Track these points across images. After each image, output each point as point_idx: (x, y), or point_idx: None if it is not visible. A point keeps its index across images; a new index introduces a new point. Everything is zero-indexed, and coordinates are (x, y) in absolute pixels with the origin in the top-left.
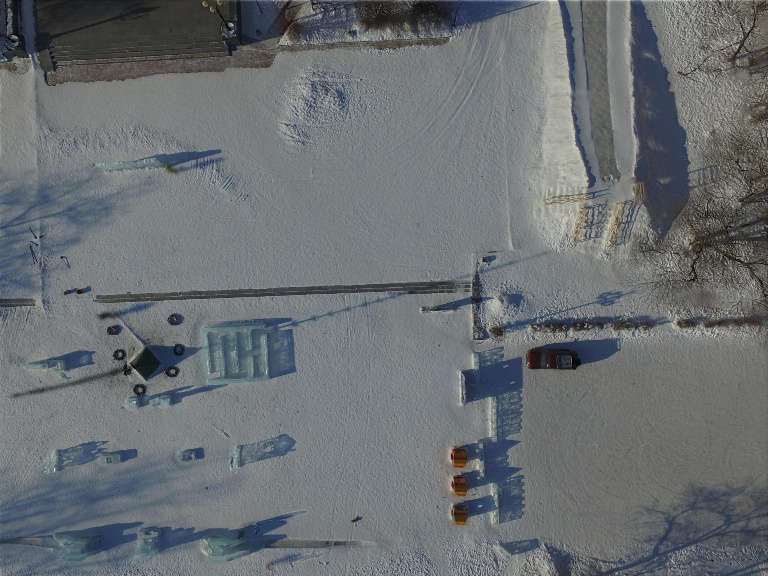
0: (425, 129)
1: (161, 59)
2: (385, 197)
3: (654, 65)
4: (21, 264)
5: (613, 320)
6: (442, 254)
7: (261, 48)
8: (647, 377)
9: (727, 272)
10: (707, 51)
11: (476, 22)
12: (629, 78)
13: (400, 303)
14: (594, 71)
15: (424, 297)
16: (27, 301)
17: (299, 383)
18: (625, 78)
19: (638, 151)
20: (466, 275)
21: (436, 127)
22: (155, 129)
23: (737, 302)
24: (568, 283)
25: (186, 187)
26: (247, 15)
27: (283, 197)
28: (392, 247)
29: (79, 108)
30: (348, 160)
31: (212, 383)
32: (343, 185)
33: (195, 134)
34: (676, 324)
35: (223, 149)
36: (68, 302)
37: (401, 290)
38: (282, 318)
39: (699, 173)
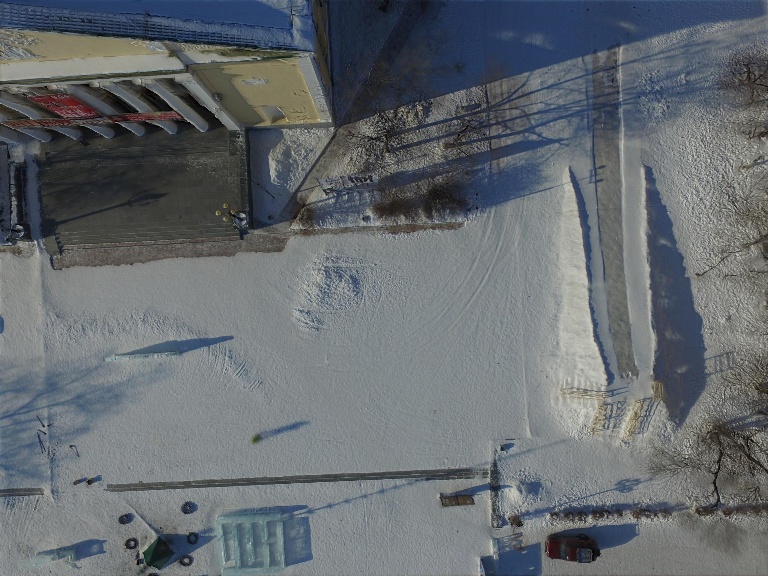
0: (441, 315)
1: (171, 243)
2: (401, 384)
3: (670, 251)
4: (29, 453)
5: (632, 507)
6: (460, 441)
7: (273, 232)
8: (666, 562)
9: (744, 458)
10: (722, 236)
11: (491, 206)
12: (646, 270)
13: (417, 489)
14: (610, 261)
15: (442, 483)
16: (35, 490)
17: (316, 571)
18: (642, 269)
19: (656, 347)
20: (484, 463)
21: (452, 313)
22: (165, 315)
23: (755, 488)
24: (586, 470)
25: (198, 374)
26: (258, 199)
27: (297, 384)
28: (409, 434)
29: (87, 293)
30: (363, 346)
31: (228, 575)
32: (358, 372)
33: (207, 320)
34: (695, 511)
35: (235, 335)
36: (78, 491)
37: (418, 477)
38: (298, 505)
39: (716, 360)
